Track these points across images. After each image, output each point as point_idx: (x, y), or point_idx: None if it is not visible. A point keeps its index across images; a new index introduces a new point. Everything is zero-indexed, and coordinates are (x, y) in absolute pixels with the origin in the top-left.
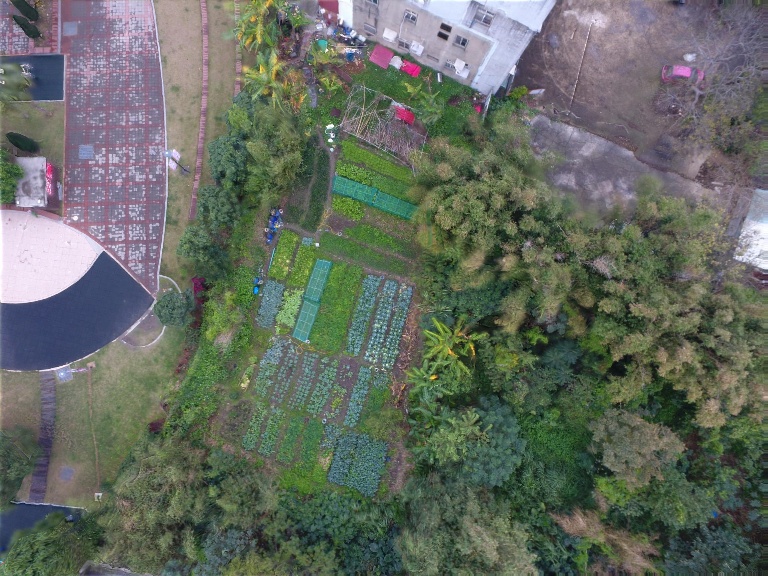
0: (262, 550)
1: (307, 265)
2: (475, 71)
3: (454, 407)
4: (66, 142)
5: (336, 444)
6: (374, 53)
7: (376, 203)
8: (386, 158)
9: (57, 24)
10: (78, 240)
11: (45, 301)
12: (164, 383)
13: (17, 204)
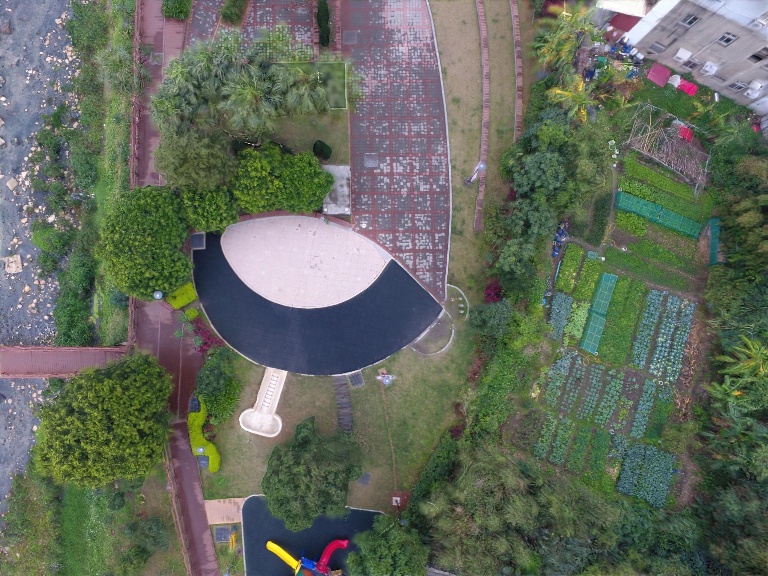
0: (615, 559)
1: (593, 278)
2: (766, 93)
3: (757, 422)
4: (351, 150)
5: (624, 455)
6: (652, 71)
7: (660, 219)
8: (667, 175)
9: (339, 33)
10: (367, 247)
11: (336, 307)
12: (456, 391)
13: (324, 211)
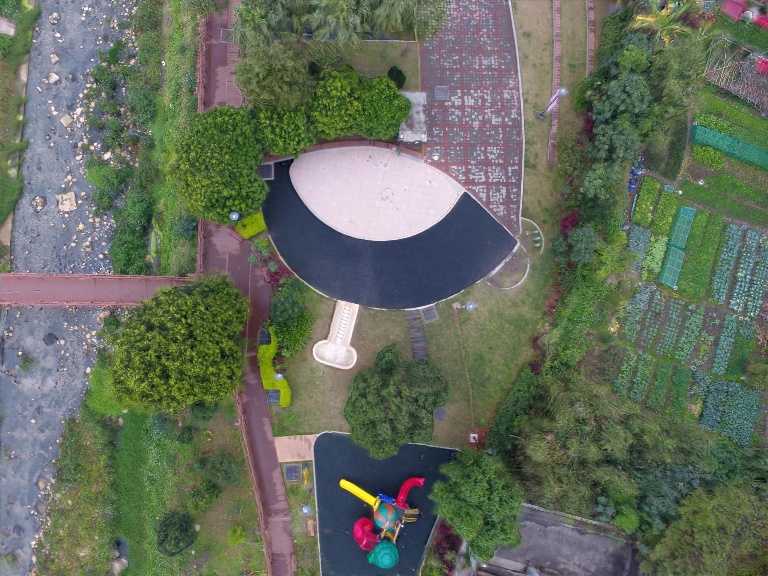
0: None
1: (671, 212)
2: None
3: None
4: (421, 82)
5: (707, 391)
6: (723, 8)
7: (737, 153)
8: (741, 110)
9: None
10: (439, 180)
11: (408, 239)
12: (534, 325)
13: (400, 138)
